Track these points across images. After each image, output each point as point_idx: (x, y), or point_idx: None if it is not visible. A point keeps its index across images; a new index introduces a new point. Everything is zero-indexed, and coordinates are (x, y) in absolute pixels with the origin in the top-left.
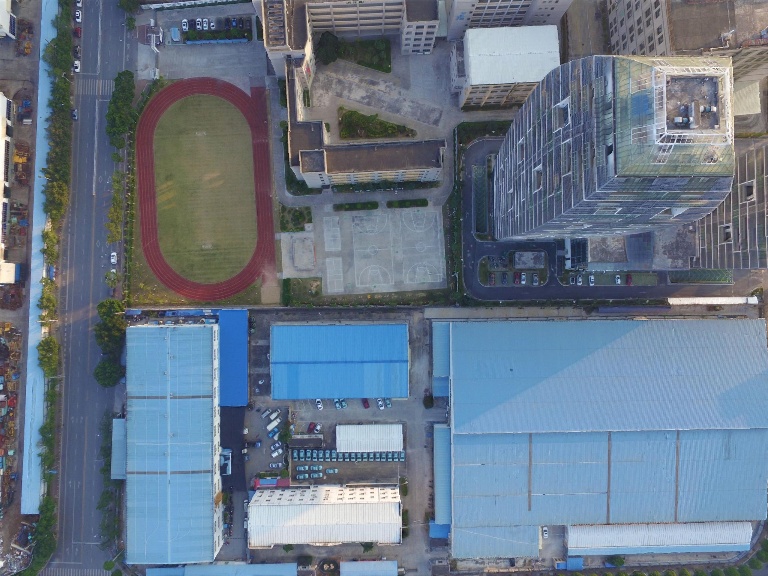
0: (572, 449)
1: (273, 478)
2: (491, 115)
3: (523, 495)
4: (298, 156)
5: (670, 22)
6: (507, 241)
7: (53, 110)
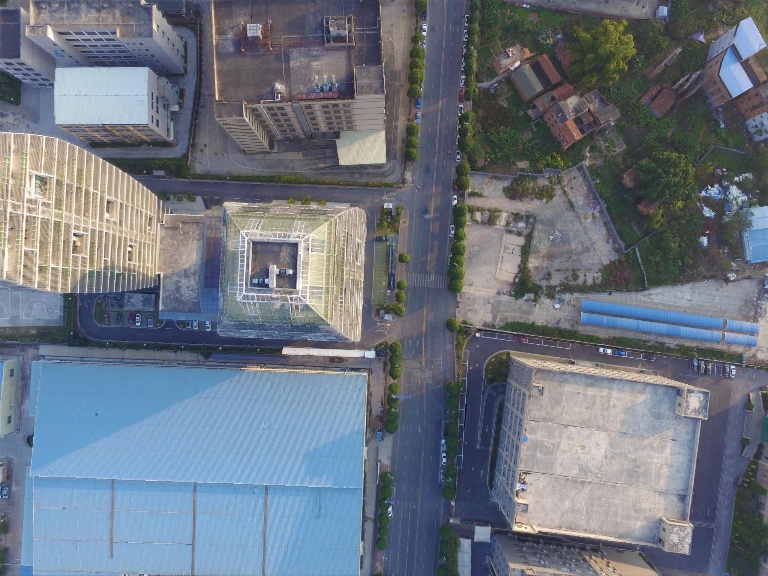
0: (156, 498)
1: None
2: (120, 152)
3: (105, 542)
4: None
5: None
6: None
7: None
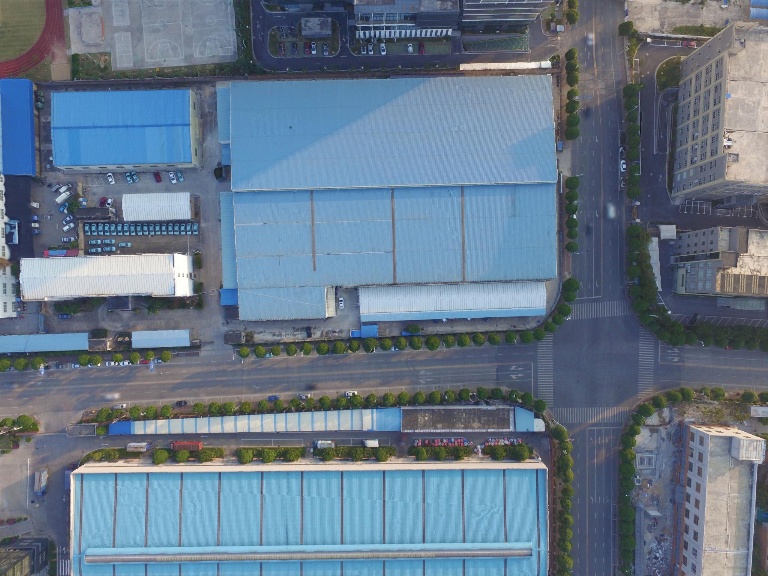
0: (355, 207)
1: (64, 250)
2: None
3: (307, 255)
4: None
5: None
6: (297, 11)
7: None
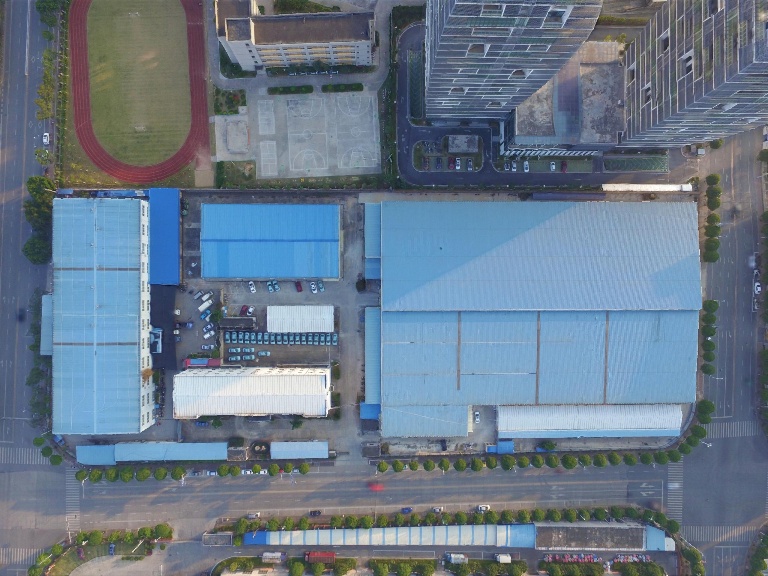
0: (501, 329)
1: (204, 359)
2: None
3: (452, 374)
4: None
5: None
6: (442, 126)
7: None
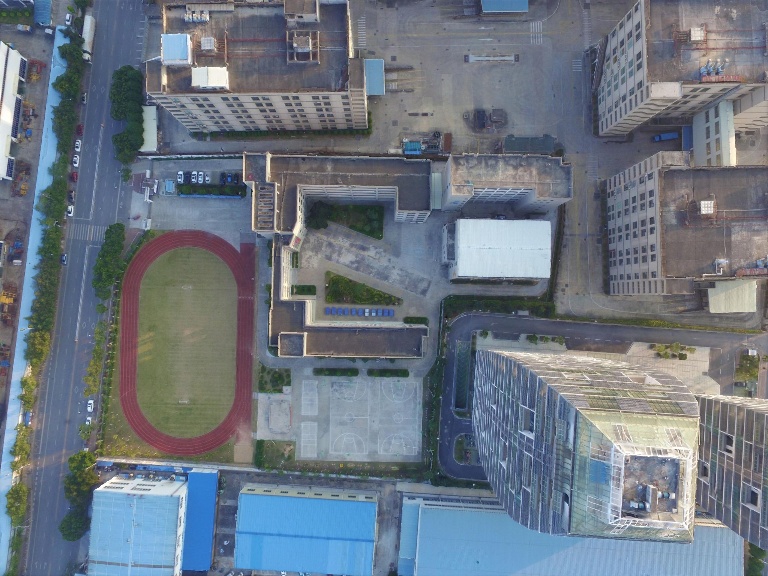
0: None
1: None
2: (480, 289)
3: None
4: (278, 334)
5: (663, 247)
6: None
7: (42, 257)
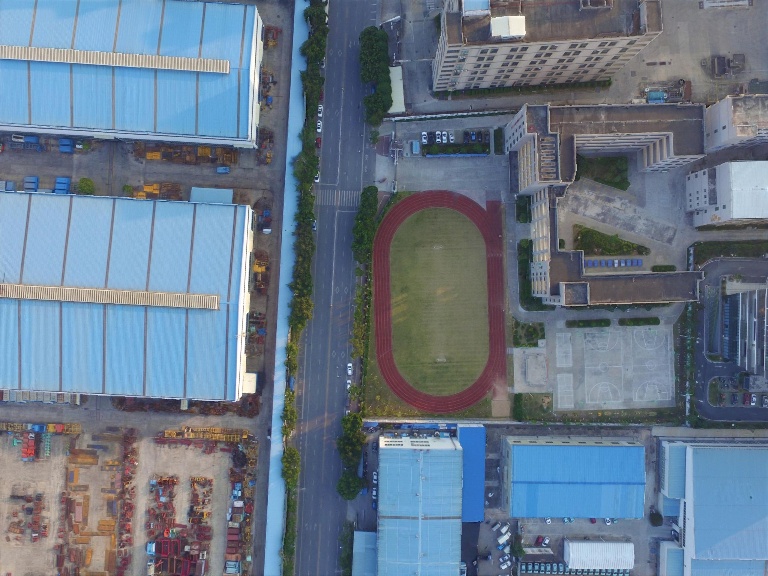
0: None
1: None
2: (725, 235)
3: None
4: (557, 285)
5: None
6: None
7: (298, 223)
